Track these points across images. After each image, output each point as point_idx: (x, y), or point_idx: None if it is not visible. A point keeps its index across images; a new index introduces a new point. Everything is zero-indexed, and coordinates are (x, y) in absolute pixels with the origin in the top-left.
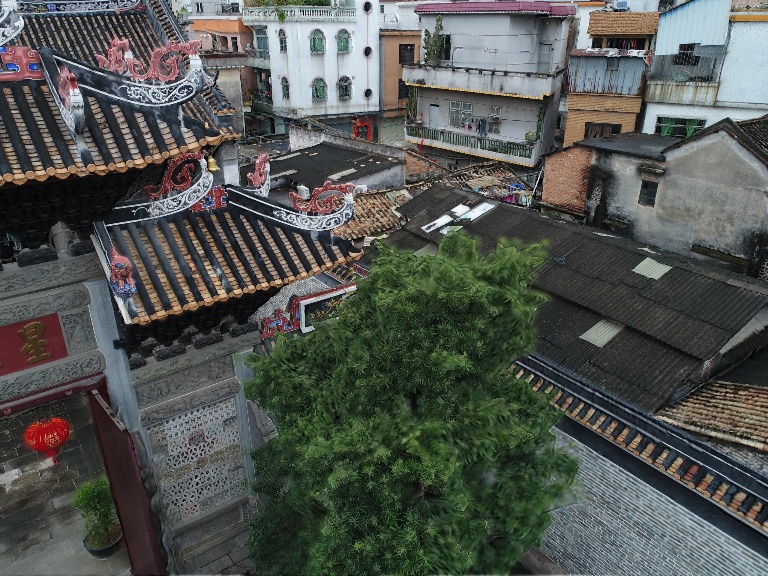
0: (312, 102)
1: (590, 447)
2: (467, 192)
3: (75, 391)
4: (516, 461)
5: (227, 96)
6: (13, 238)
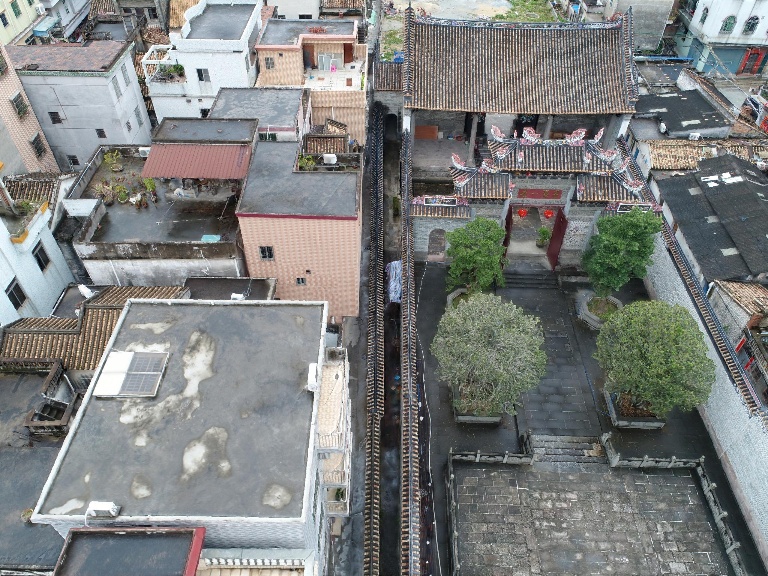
0: (719, 33)
1: (678, 273)
2: (738, 166)
3: (558, 207)
4: (640, 256)
5: (659, 11)
6: None
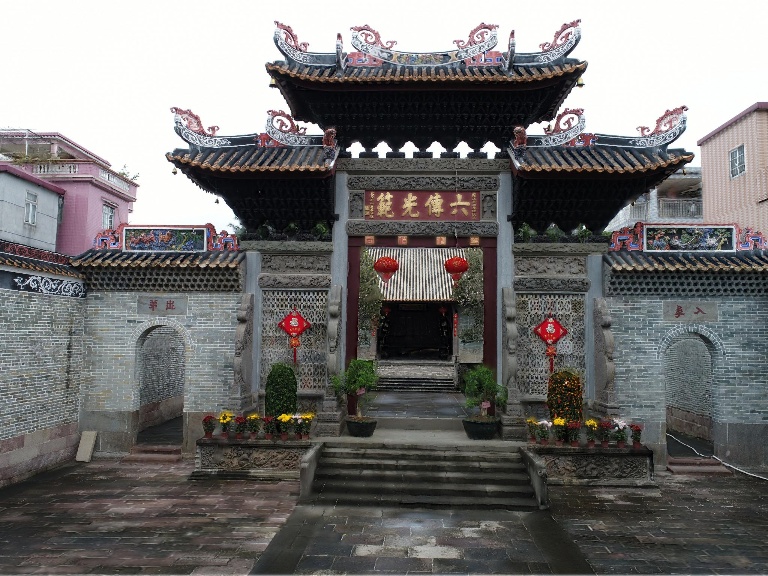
0: None
1: None
2: None
3: None
4: None
5: None
6: (378, 145)
